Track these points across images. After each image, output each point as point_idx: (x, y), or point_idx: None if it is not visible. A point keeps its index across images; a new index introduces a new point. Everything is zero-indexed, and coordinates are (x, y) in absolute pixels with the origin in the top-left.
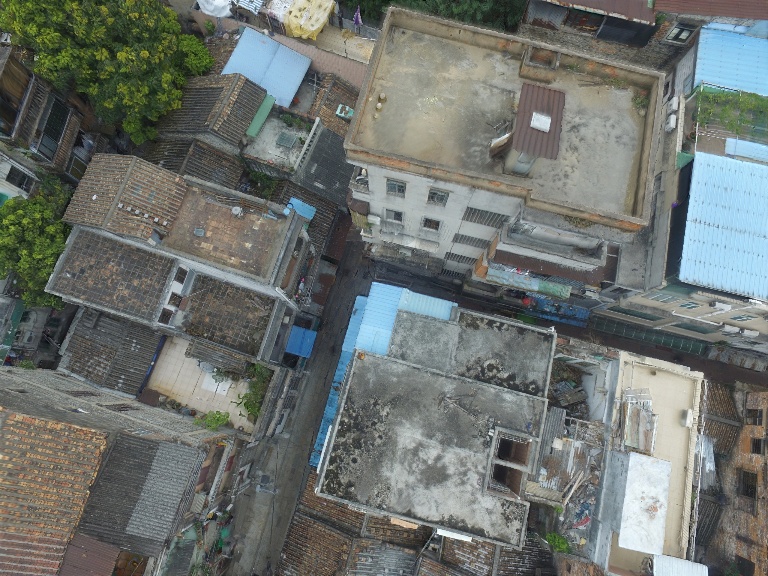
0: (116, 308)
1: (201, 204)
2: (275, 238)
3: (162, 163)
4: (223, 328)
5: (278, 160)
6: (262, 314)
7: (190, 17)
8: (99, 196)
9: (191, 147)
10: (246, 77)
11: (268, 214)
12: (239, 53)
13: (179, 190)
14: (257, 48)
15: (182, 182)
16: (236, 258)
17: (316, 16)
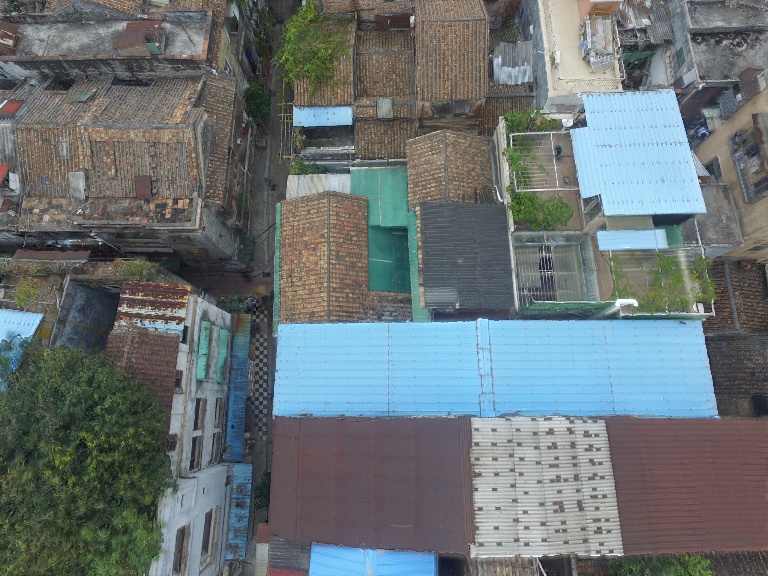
0: None
1: None
2: None
3: None
4: None
5: None
6: None
7: None
8: None
9: None
10: None
11: None
12: None
13: None
14: None
15: None
16: None
17: None
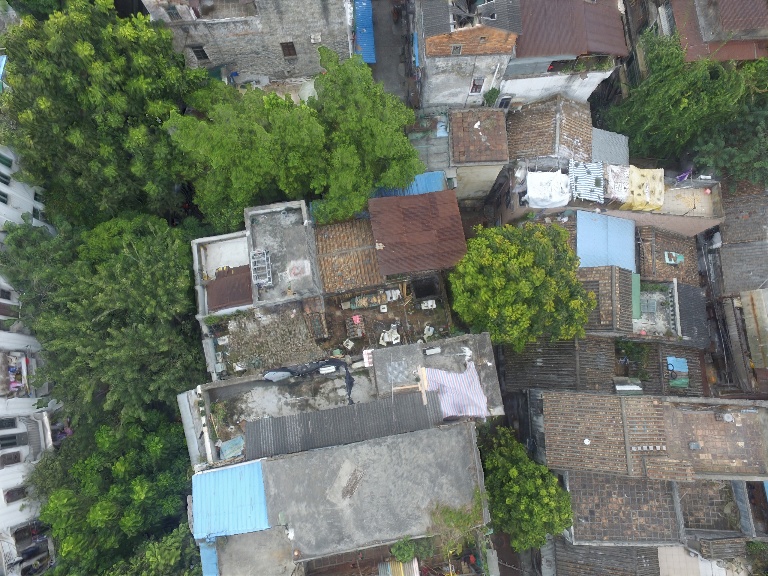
0: (642, 539)
1: (679, 417)
2: (761, 430)
3: (541, 361)
4: (692, 512)
5: (648, 328)
6: (720, 487)
7: (466, 197)
8: (593, 440)
9: (576, 342)
10: (618, 266)
11: (747, 409)
12: (582, 238)
13: (658, 411)
14: (593, 227)
15: (658, 402)
16: (737, 460)
17: (658, 190)
